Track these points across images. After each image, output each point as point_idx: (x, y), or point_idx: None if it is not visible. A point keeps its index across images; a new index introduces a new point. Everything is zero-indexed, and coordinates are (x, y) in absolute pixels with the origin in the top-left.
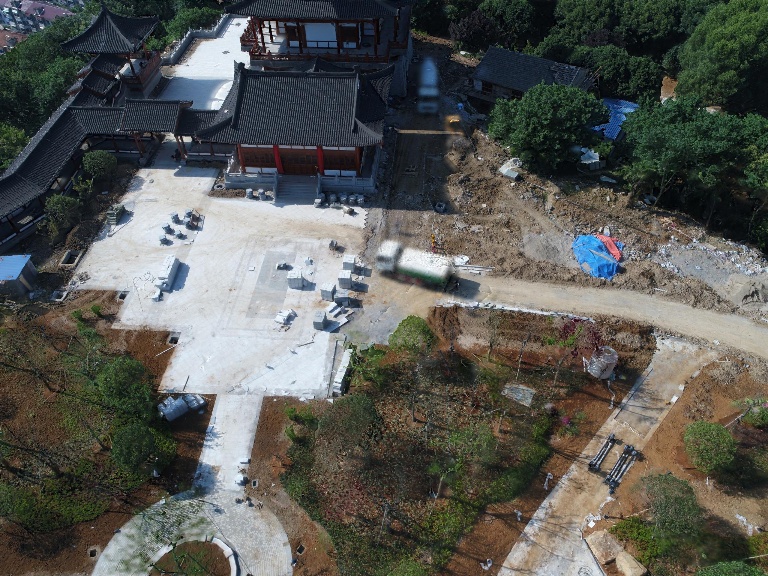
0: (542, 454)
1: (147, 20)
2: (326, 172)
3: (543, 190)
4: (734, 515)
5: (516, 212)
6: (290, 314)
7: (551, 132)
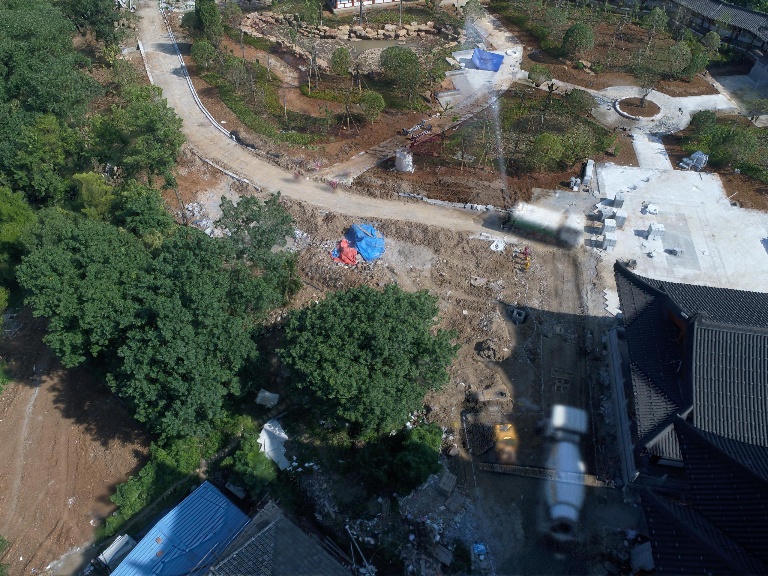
0: None
1: None
2: None
3: None
4: None
5: (432, 291)
6: None
7: None
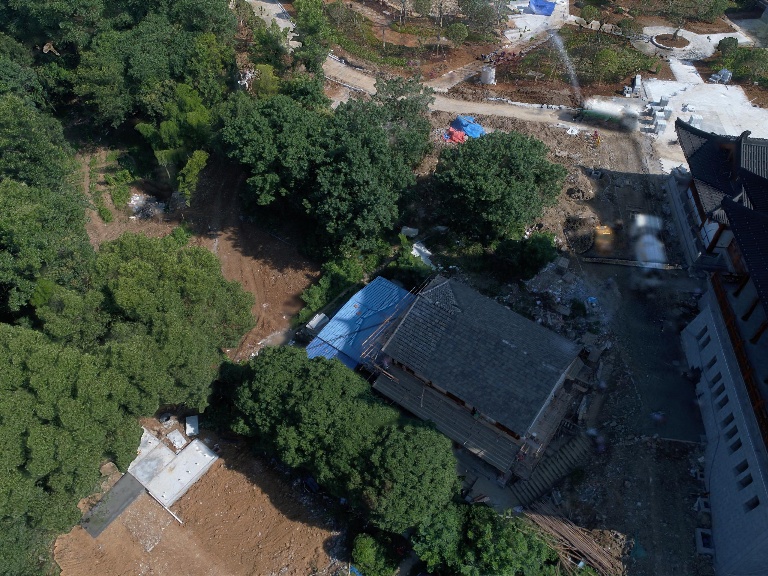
0: None
1: None
2: None
3: None
4: (448, 41)
5: None
6: None
7: None
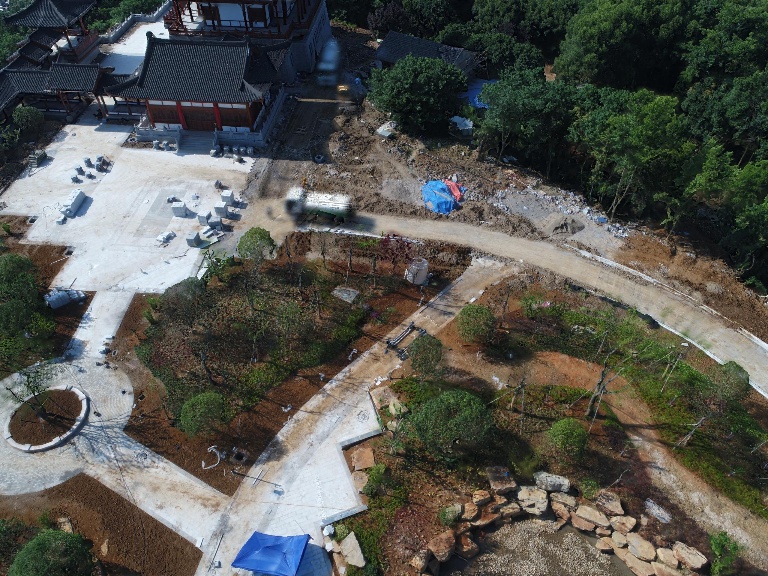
0: (351, 335)
1: (84, 1)
2: (224, 128)
3: (411, 147)
4: (491, 377)
5: (381, 162)
6: (170, 235)
7: (413, 95)
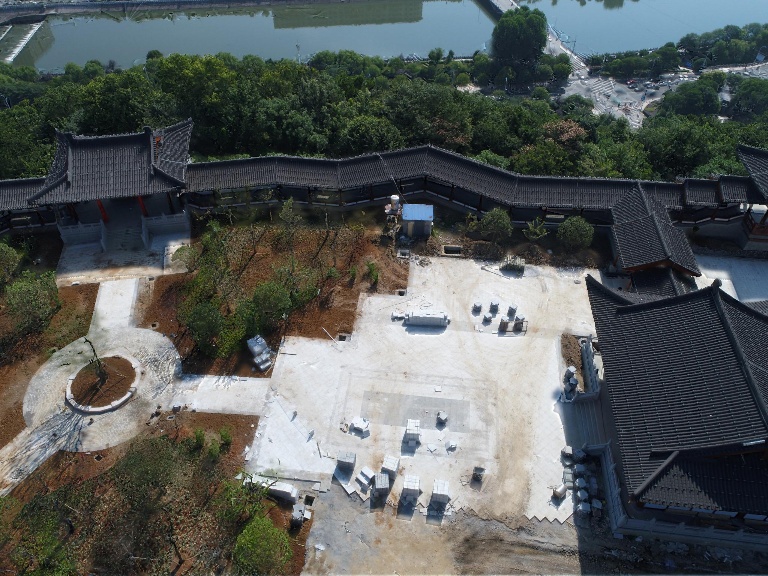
0: None
1: None
2: None
3: None
4: None
5: None
6: None
7: None
